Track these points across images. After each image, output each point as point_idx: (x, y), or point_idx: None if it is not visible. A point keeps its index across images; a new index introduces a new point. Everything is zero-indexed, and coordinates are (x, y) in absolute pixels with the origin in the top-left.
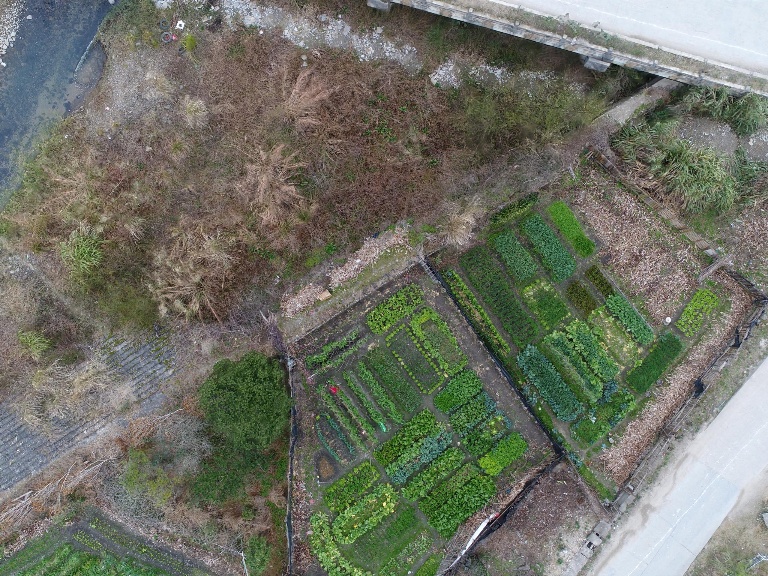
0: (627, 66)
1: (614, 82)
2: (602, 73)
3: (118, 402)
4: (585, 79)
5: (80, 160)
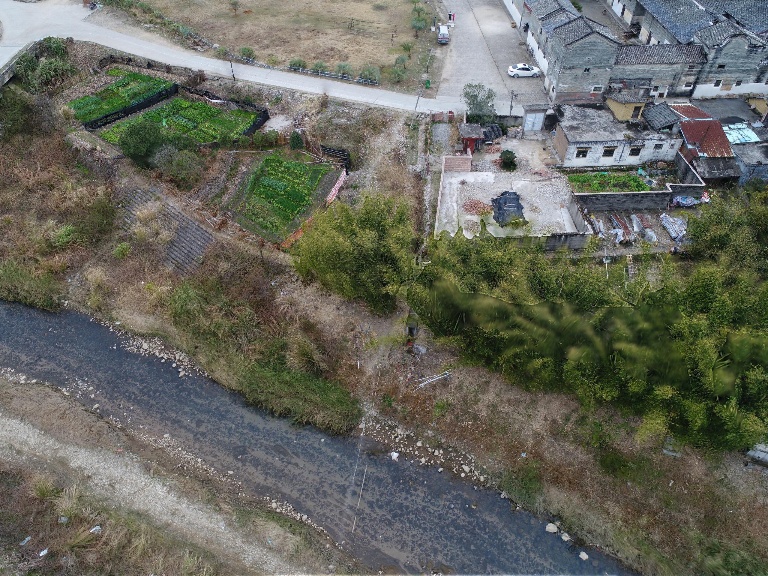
0: (0, 86)
1: (7, 89)
2: (3, 103)
3: (156, 204)
4: (6, 113)
5: (7, 268)
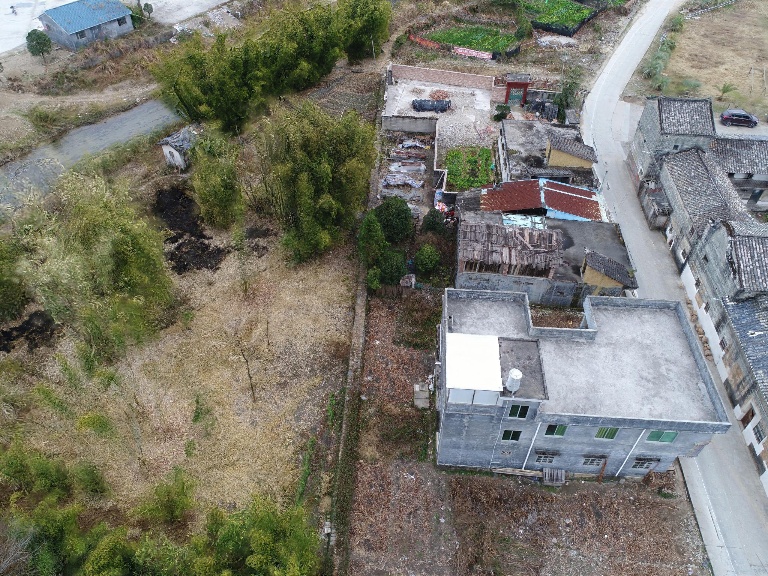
0: None
1: None
2: None
3: None
4: None
5: None
